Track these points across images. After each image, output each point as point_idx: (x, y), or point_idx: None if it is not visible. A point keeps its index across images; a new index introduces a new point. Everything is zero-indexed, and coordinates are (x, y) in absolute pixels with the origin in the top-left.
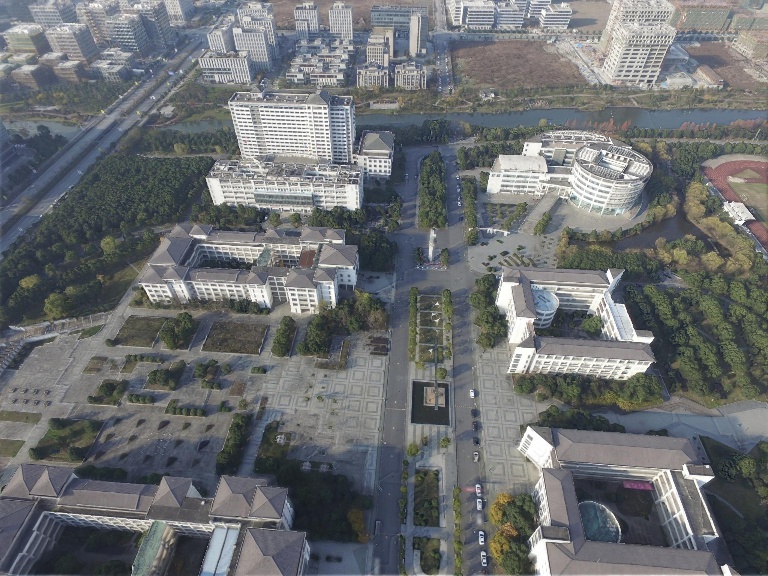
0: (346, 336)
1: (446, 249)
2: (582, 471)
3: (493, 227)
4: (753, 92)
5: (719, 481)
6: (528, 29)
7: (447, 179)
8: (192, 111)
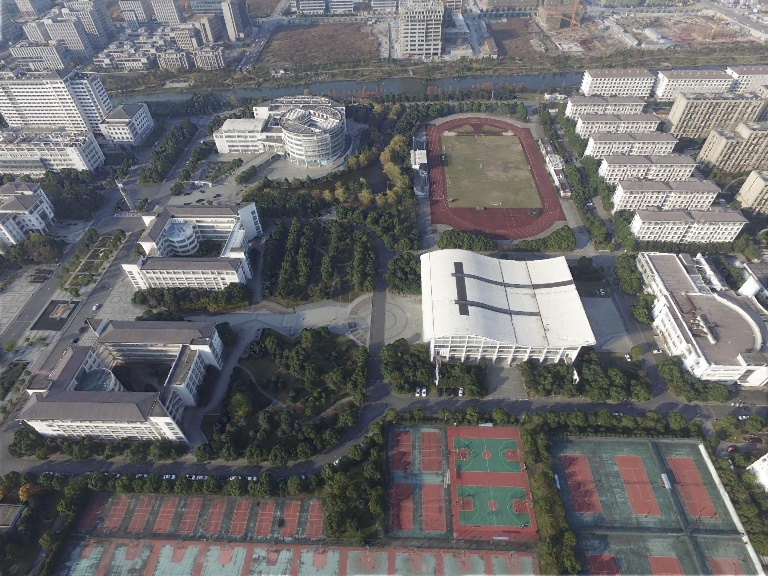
0: (17, 270)
1: (145, 199)
2: (134, 354)
3: (205, 180)
4: (524, 60)
5: (254, 358)
6: (359, 12)
7: (192, 144)
8: None
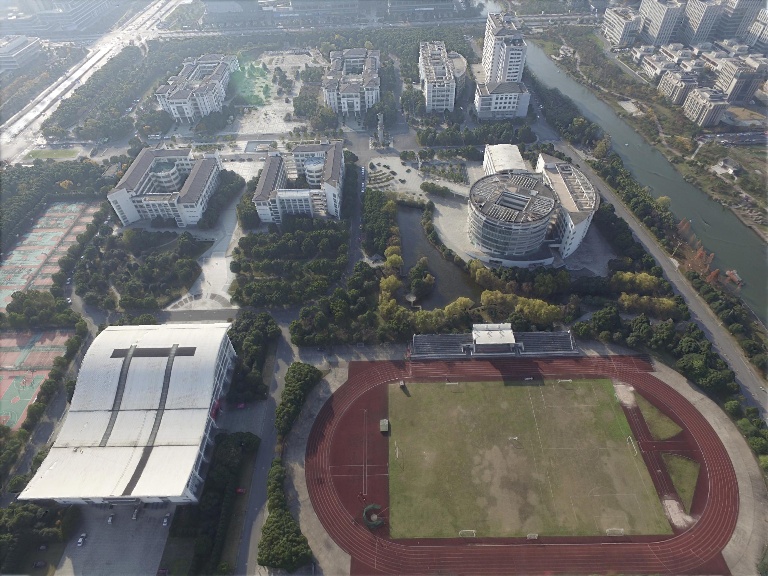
0: None
1: None
2: None
3: None
4: None
5: None
6: None
7: None
8: (544, 37)
